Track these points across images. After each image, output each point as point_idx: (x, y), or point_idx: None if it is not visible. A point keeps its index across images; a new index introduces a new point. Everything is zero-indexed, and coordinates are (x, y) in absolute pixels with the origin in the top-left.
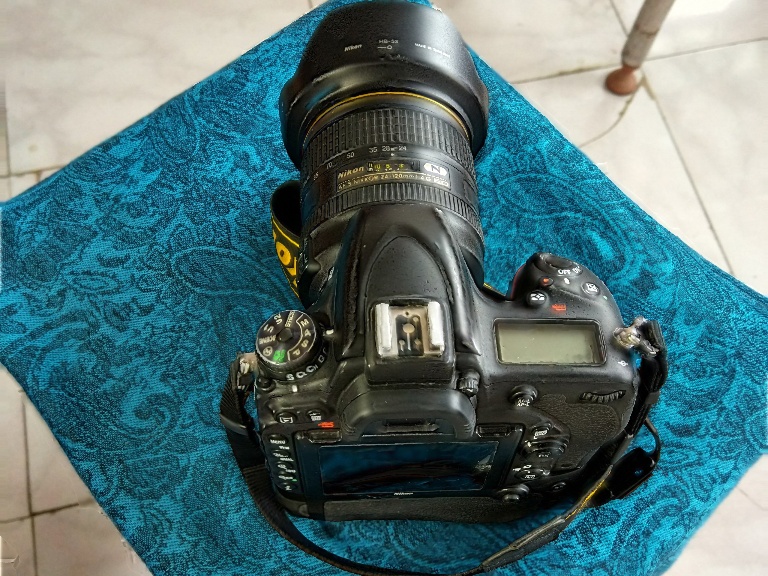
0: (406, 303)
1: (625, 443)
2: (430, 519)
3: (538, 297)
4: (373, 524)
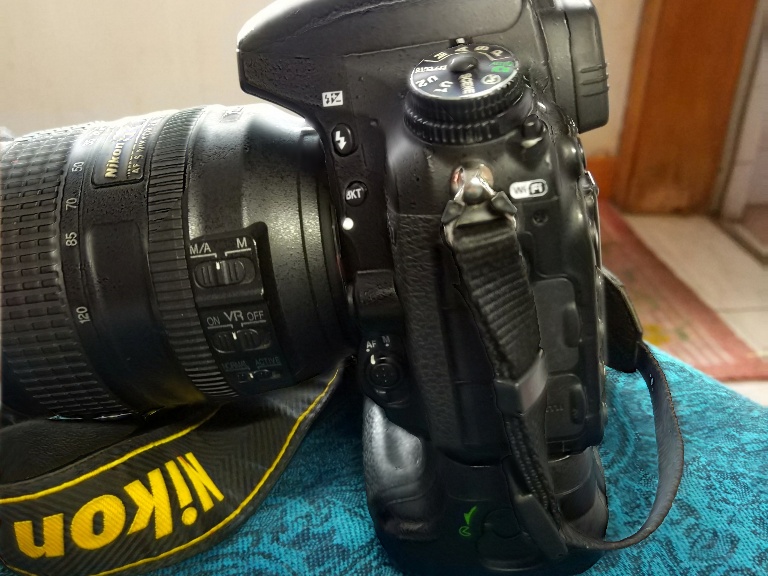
0: None
1: None
2: None
3: None
4: None
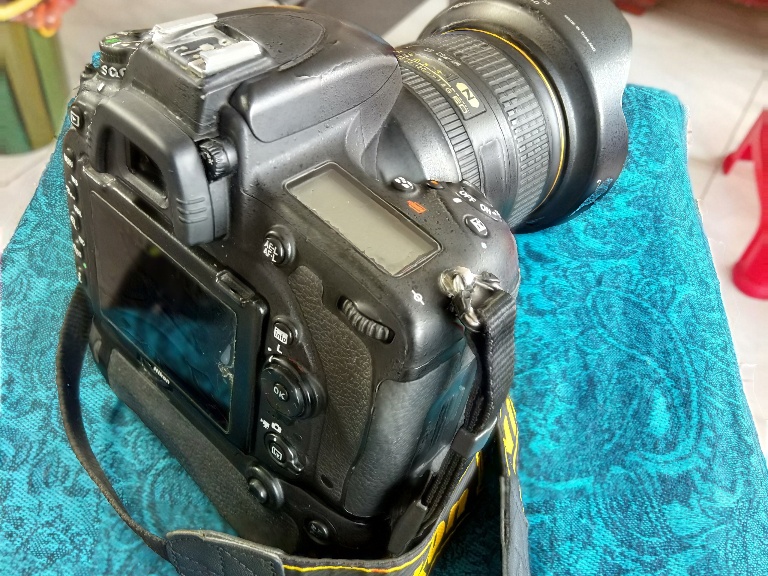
0: (236, 36)
1: (411, 512)
2: (187, 467)
3: (403, 181)
4: (154, 446)
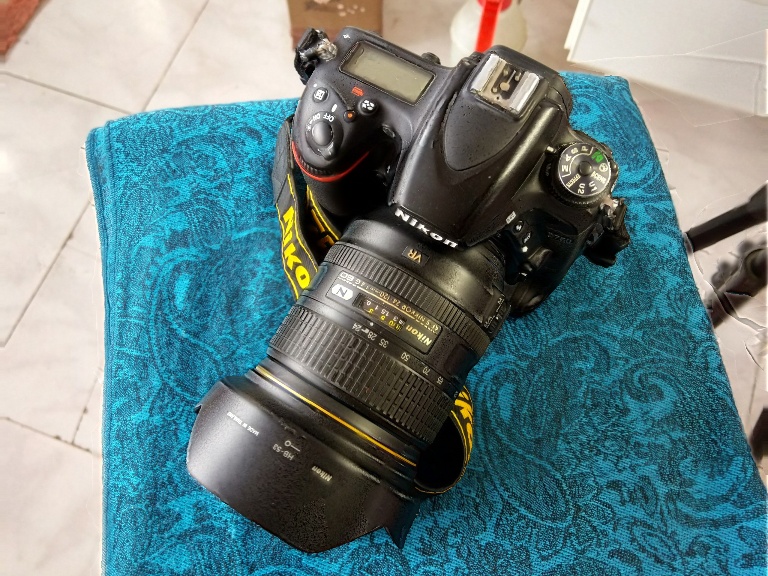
0: None
1: None
2: None
3: (368, 105)
4: None
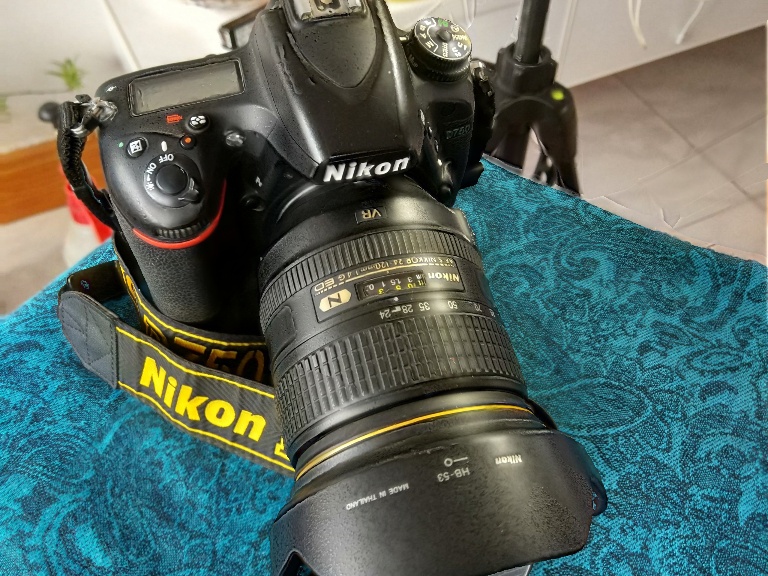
0: None
1: None
2: None
3: (198, 119)
4: None
